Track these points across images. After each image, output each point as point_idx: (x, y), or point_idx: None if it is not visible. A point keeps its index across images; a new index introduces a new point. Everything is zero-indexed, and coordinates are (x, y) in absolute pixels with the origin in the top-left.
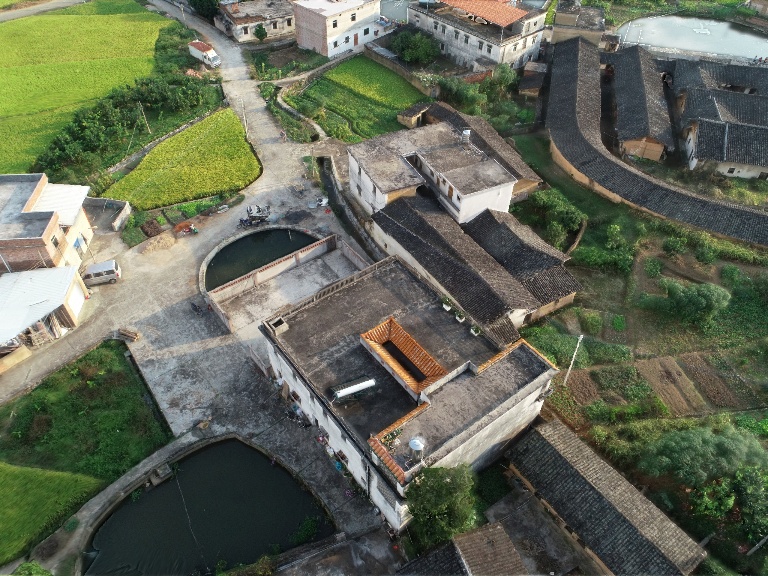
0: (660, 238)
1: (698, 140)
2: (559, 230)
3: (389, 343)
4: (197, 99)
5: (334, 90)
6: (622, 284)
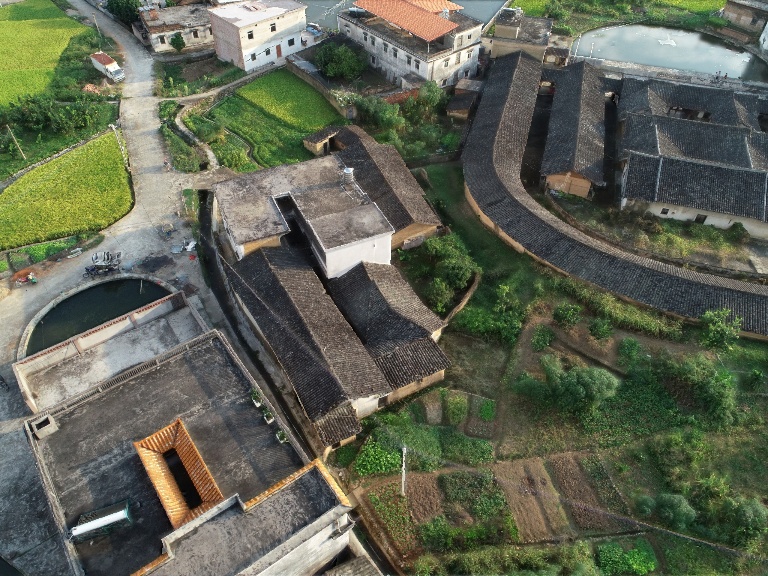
0: (558, 300)
1: (628, 176)
2: (442, 288)
3: (172, 452)
4: (84, 119)
5: (243, 109)
6: (503, 358)
